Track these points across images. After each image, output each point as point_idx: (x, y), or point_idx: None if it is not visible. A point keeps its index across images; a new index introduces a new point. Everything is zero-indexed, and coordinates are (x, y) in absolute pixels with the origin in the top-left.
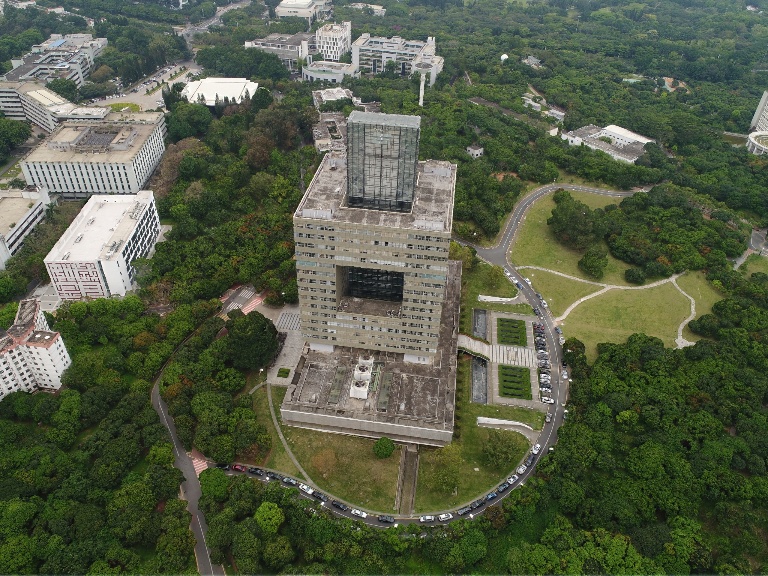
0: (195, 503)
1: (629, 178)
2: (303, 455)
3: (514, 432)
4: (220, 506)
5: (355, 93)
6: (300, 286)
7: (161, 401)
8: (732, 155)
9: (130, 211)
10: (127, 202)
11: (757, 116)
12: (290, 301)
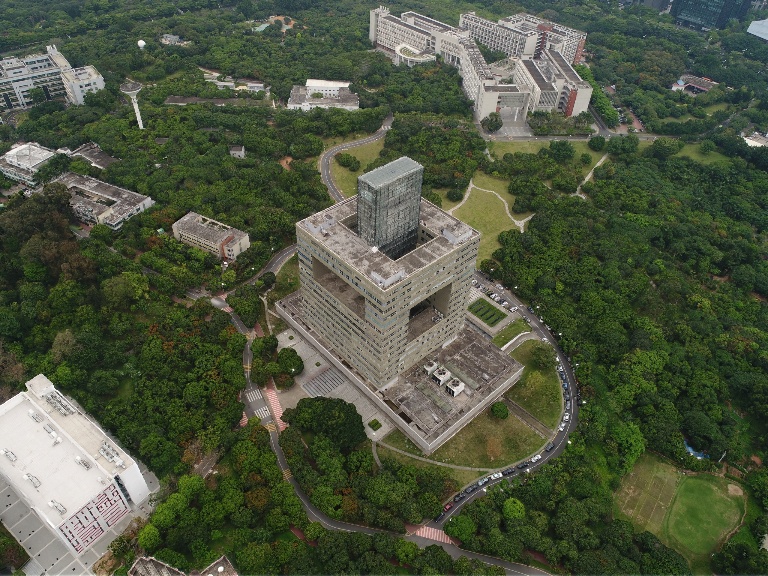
0: (458, 554)
1: (374, 122)
2: (465, 460)
3: (526, 342)
4: (483, 535)
5: (48, 144)
6: (383, 345)
7: (335, 525)
8: (407, 73)
9: (50, 410)
10: (13, 407)
11: (373, 32)
12: (299, 372)
